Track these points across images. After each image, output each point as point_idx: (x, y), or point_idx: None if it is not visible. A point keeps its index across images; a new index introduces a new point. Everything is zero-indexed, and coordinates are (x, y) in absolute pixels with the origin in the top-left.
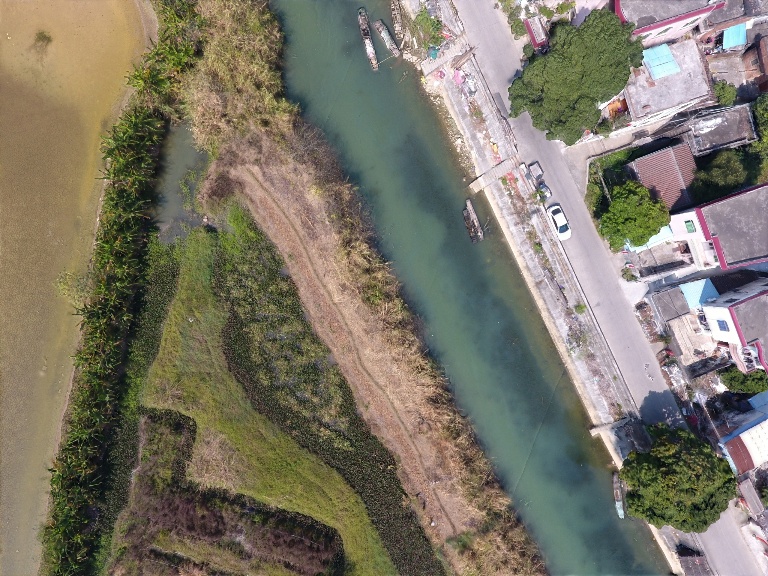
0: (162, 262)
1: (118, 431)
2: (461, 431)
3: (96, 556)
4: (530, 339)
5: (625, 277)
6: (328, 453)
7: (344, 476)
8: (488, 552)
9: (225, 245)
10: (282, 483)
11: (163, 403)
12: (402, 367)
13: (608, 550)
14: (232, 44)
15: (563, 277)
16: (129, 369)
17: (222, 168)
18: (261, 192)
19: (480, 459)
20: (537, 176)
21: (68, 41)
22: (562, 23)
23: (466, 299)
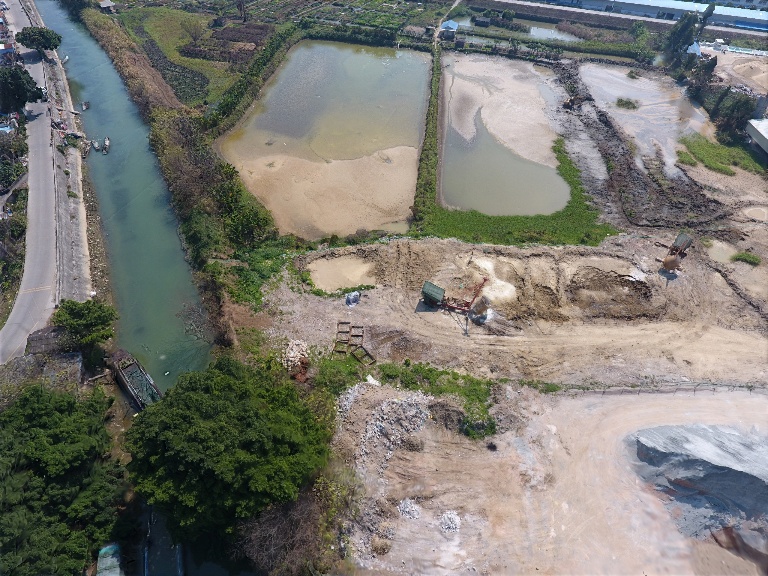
0: None
1: None
2: None
3: None
4: (79, 86)
5: None
6: None
7: None
8: None
9: None
10: None
11: None
12: None
13: None
14: (168, 121)
15: None
16: None
17: None
18: None
19: None
20: None
21: None
22: None
23: None
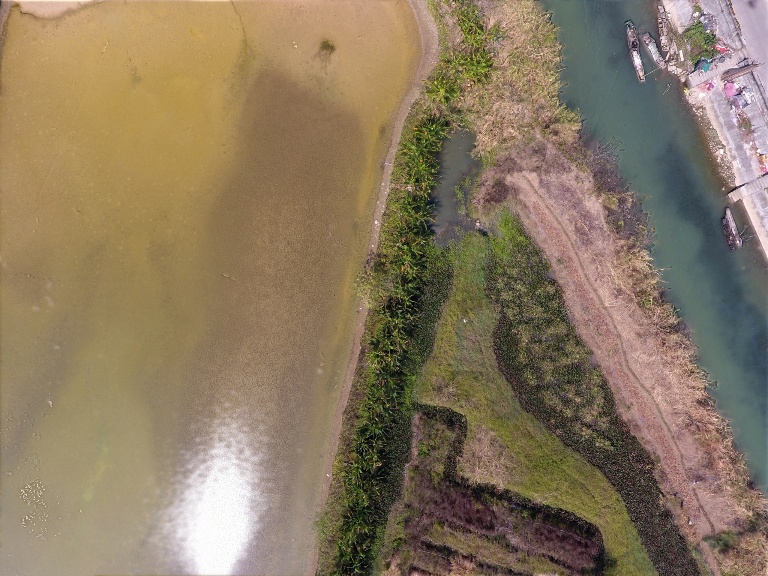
0: (439, 264)
1: (394, 426)
2: (727, 433)
3: (371, 546)
4: None
5: None
6: (589, 452)
7: (605, 474)
8: (753, 551)
9: (496, 249)
10: (549, 480)
11: (438, 400)
12: (676, 370)
13: None
14: (530, 56)
15: None
16: (405, 367)
17: (499, 174)
18: (535, 198)
19: (740, 461)
20: None
21: (350, 50)
22: None
23: (722, 305)
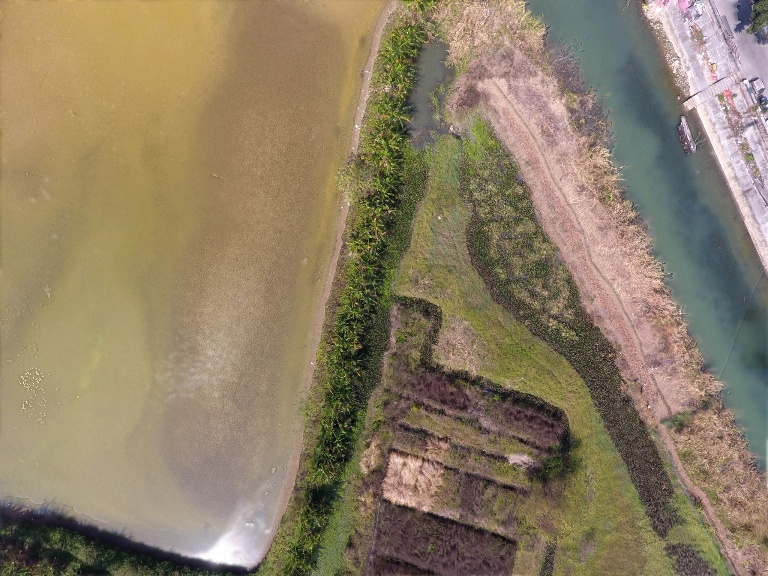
0: (415, 165)
1: (374, 316)
2: (682, 320)
3: (353, 428)
4: (733, 244)
5: None
6: (556, 341)
7: (571, 362)
8: (706, 428)
9: (468, 152)
10: (518, 366)
11: (415, 291)
12: (634, 260)
13: None
14: None
15: None
16: (384, 261)
17: (471, 81)
18: (504, 103)
19: (694, 348)
20: (759, 90)
21: None
22: None
23: (678, 206)
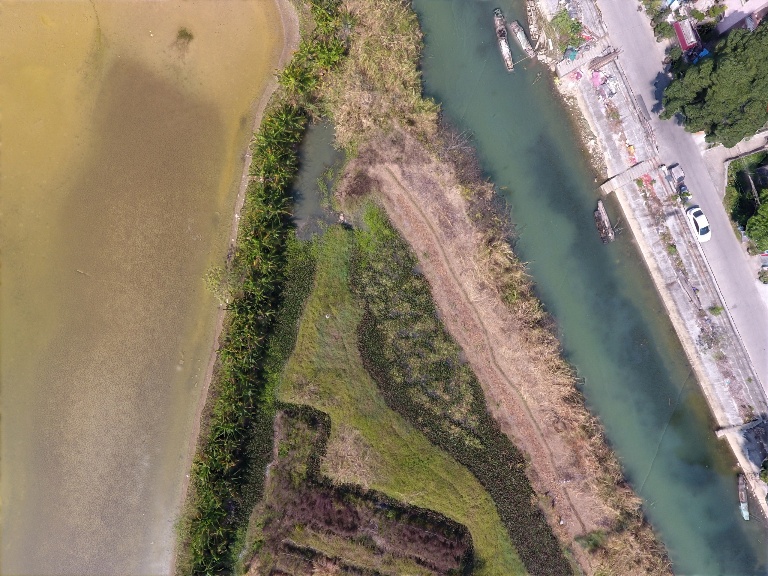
0: (300, 259)
1: (254, 425)
2: (595, 430)
3: (231, 549)
4: (657, 340)
5: (762, 280)
6: (458, 450)
7: (474, 473)
8: (621, 551)
9: (360, 243)
10: (415, 479)
11: (300, 398)
12: (540, 366)
13: (731, 551)
14: (382, 43)
15: (698, 279)
16: (266, 364)
17: (361, 166)
18: (399, 190)
19: (611, 459)
20: (678, 178)
21: (209, 39)
22: (711, 26)
23: (595, 299)
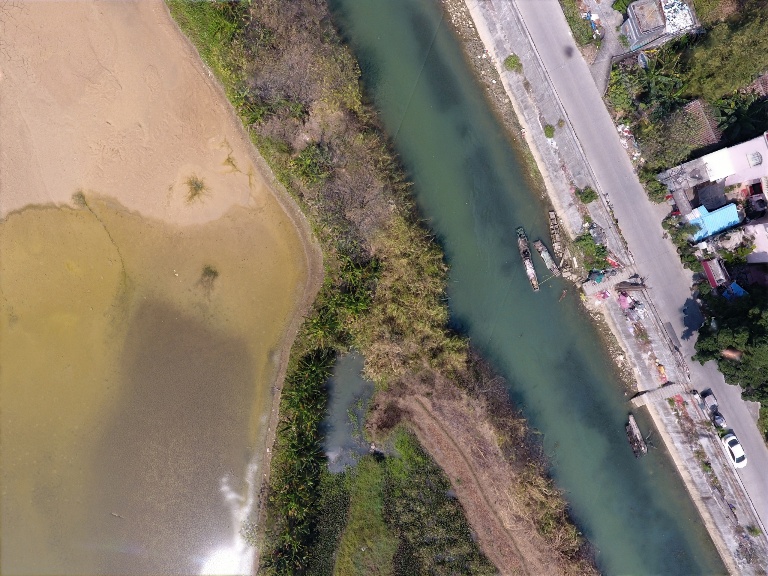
0: (333, 492)
1: None
2: None
3: None
4: (694, 549)
5: None
6: None
7: None
8: None
9: (393, 471)
10: None
11: None
12: None
13: None
14: (409, 291)
15: (735, 499)
16: None
17: (391, 398)
18: (429, 420)
19: None
20: (711, 406)
21: (233, 274)
22: (739, 261)
23: (630, 513)
